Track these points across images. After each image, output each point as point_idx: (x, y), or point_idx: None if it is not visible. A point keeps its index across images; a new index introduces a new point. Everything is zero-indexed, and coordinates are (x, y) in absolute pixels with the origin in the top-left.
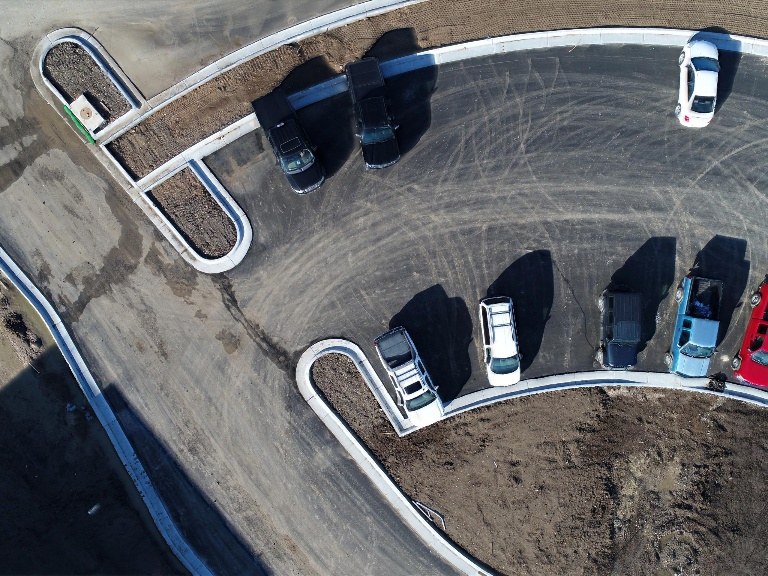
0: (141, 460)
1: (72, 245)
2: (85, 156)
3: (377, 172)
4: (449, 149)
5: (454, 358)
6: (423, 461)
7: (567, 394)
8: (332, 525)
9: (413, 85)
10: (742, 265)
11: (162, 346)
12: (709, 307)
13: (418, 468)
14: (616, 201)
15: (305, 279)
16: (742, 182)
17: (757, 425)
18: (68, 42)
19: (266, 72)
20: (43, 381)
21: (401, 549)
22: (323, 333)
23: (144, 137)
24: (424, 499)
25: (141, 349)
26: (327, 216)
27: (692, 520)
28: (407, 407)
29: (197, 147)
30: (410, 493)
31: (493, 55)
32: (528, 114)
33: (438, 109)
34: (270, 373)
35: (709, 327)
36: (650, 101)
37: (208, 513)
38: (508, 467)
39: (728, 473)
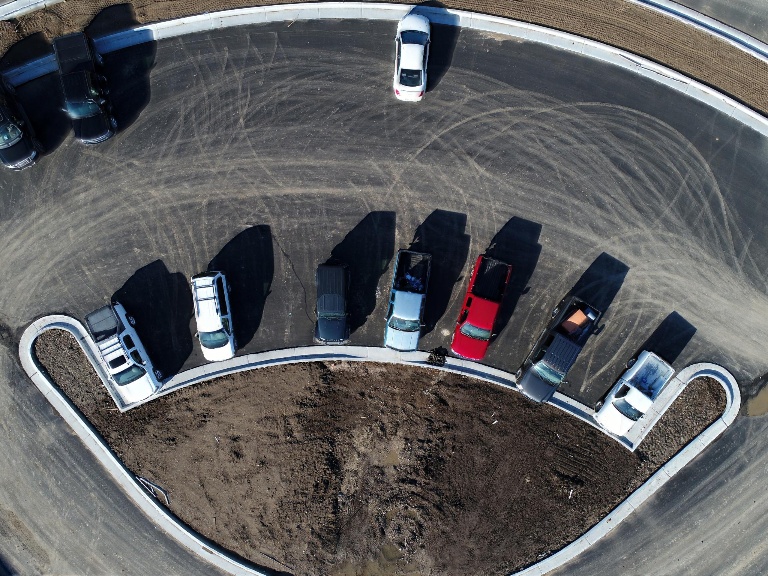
0: None
1: None
2: None
3: (97, 148)
4: (169, 125)
5: (175, 334)
6: (145, 437)
7: (287, 369)
8: (56, 501)
9: (132, 61)
10: (462, 239)
11: None
12: (420, 281)
13: (140, 444)
14: (335, 176)
15: (27, 255)
16: (462, 156)
17: (478, 399)
18: None
19: None
20: None
21: (126, 525)
22: (46, 309)
23: None
24: (147, 475)
25: None
26: (48, 192)
27: (416, 495)
28: (117, 382)
29: None
30: (133, 469)
31: (212, 30)
32: (247, 89)
33: (157, 85)
34: None
35: (411, 300)
36: (369, 76)
37: None
38: (229, 442)
39: (450, 447)
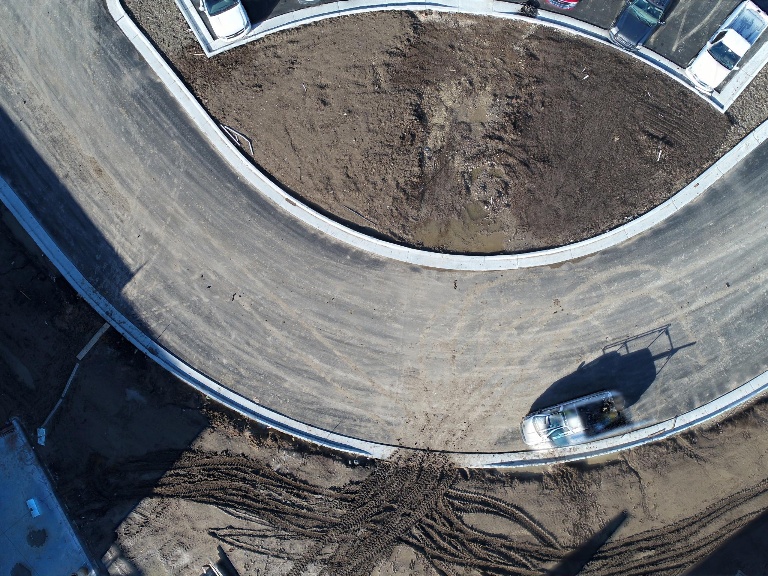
0: None
1: None
2: None
3: None
4: None
5: None
6: (231, 83)
7: (378, 17)
8: (139, 148)
9: None
10: None
11: None
12: None
13: (226, 90)
14: None
15: None
16: None
17: (569, 53)
18: None
19: None
20: None
21: (209, 175)
22: None
23: None
24: (232, 123)
25: None
26: None
27: (503, 151)
28: (208, 11)
29: None
30: (218, 116)
31: None
32: None
33: None
34: None
35: None
36: None
37: (13, 133)
38: (317, 90)
39: (540, 103)
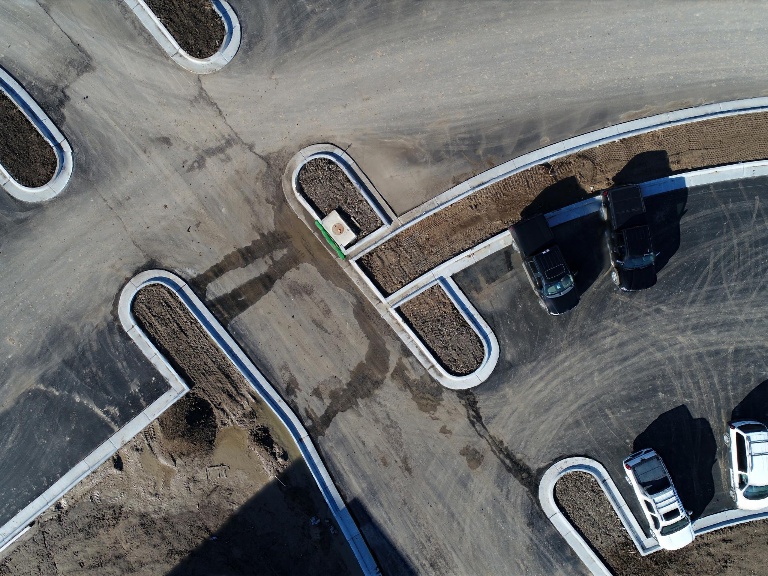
0: (383, 574)
1: (320, 359)
2: (334, 271)
3: (625, 292)
4: (697, 271)
5: (697, 478)
6: None
7: None
8: None
9: (663, 207)
10: None
11: (406, 461)
12: None
13: None
14: None
15: (550, 397)
16: None
17: None
18: (322, 158)
19: (517, 191)
20: (290, 495)
21: None
22: (567, 451)
23: (394, 253)
24: None
25: (386, 464)
26: (574, 335)
27: None
28: (661, 531)
29: (447, 264)
30: None
31: (743, 179)
32: None
33: (687, 231)
34: (513, 489)
35: None
36: None
37: None
38: None
39: None
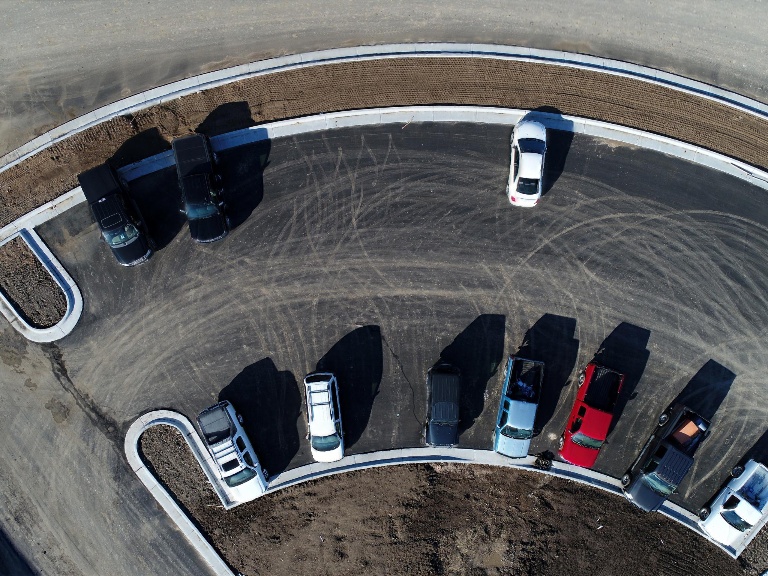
0: None
1: None
2: None
3: (209, 244)
4: (281, 223)
5: (282, 432)
6: (249, 534)
7: (394, 470)
8: None
9: (246, 158)
10: (571, 344)
11: None
12: (532, 387)
13: (244, 541)
14: (446, 278)
15: (135, 350)
16: (572, 261)
17: (583, 504)
18: None
19: (99, 143)
20: None
21: None
22: (152, 404)
23: None
24: (250, 572)
25: None
26: (158, 287)
27: None
28: (227, 483)
29: (29, 216)
30: (236, 566)
31: (326, 130)
32: (360, 190)
33: (270, 183)
34: (99, 443)
35: (526, 410)
36: (482, 179)
37: None
38: (334, 542)
39: (554, 551)
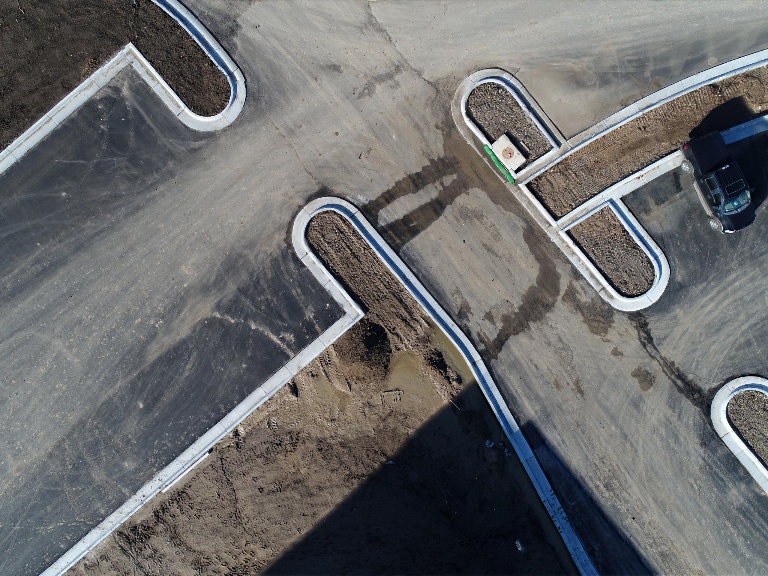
0: (557, 496)
1: (491, 283)
2: (504, 195)
3: None
4: None
5: None
6: None
7: None
8: (745, 560)
9: None
10: None
11: (578, 383)
12: None
13: None
14: None
15: (721, 317)
16: None
17: None
18: (491, 83)
19: (686, 112)
20: (465, 418)
21: None
22: (738, 370)
23: (563, 176)
24: None
25: (558, 386)
26: (744, 255)
27: None
28: None
29: (616, 186)
30: None
31: None
32: None
33: None
34: (685, 410)
35: None
36: None
37: (623, 548)
38: None
39: None
